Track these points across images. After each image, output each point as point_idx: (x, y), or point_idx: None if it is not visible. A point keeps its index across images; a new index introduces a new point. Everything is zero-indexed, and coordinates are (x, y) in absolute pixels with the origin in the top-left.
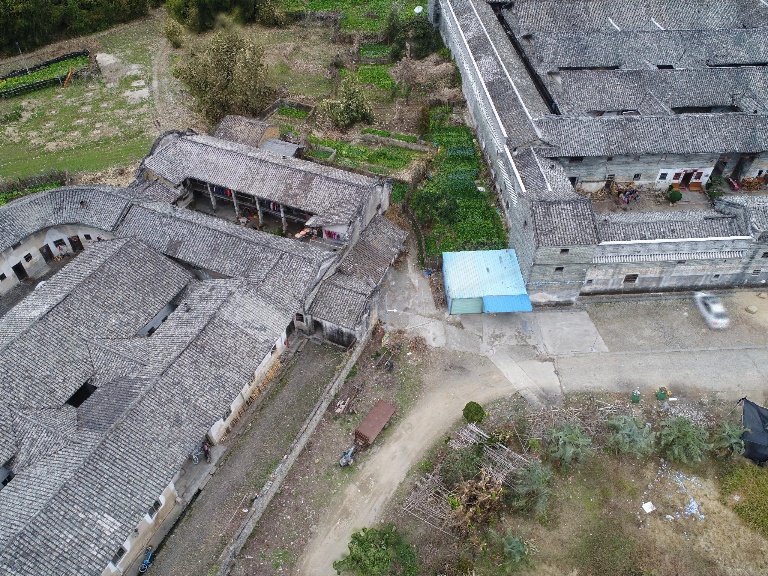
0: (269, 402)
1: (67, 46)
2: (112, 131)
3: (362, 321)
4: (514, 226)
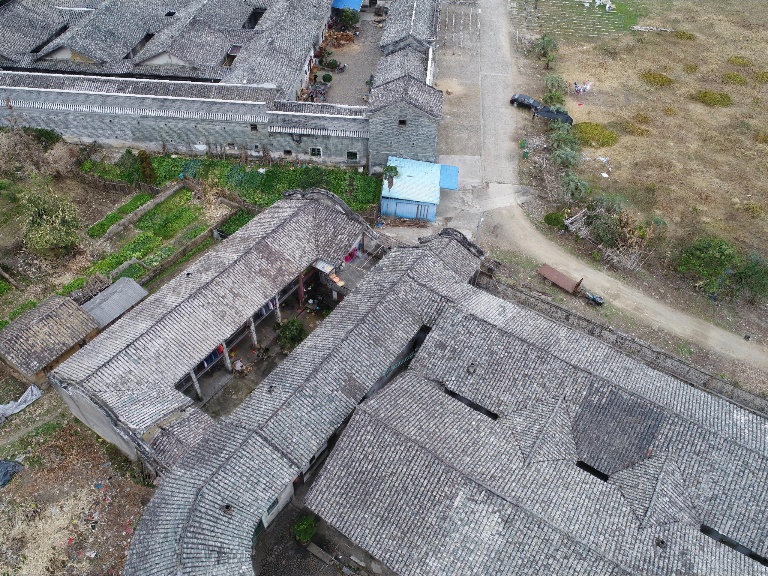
0: None
1: None
2: None
3: None
4: (376, 141)
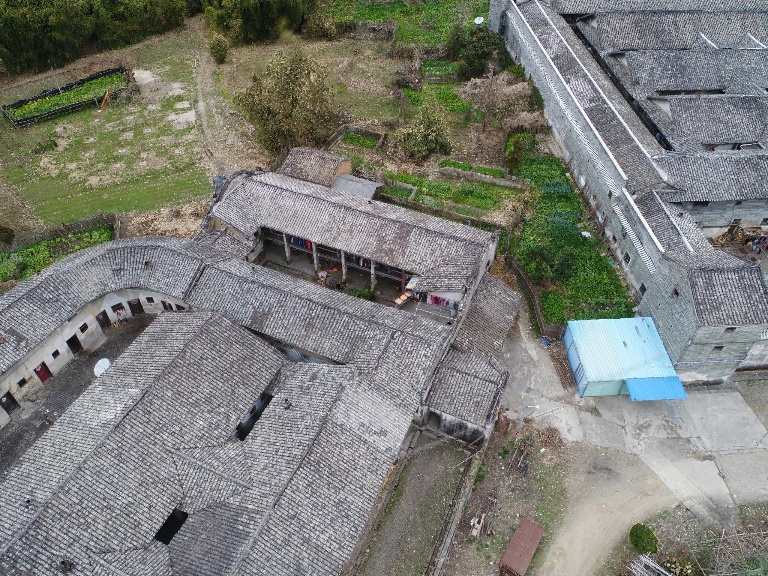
0: (386, 518)
1: (99, 61)
2: (160, 162)
3: (494, 417)
4: (651, 290)
